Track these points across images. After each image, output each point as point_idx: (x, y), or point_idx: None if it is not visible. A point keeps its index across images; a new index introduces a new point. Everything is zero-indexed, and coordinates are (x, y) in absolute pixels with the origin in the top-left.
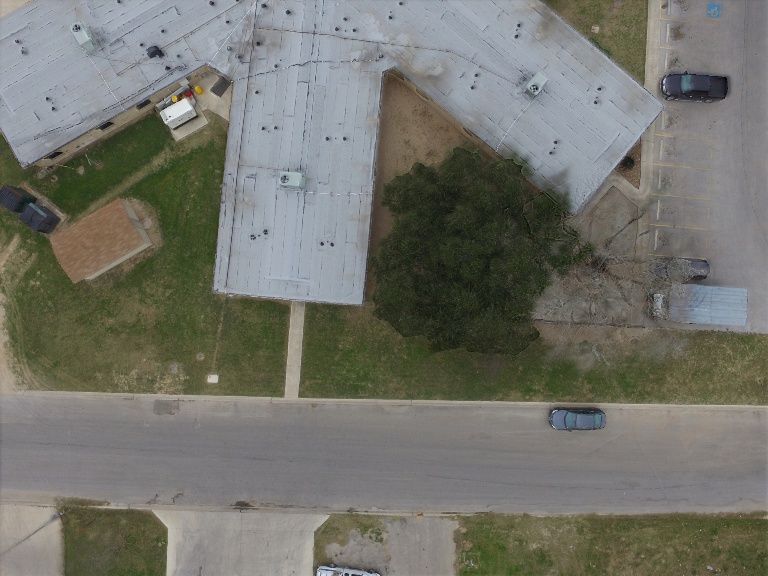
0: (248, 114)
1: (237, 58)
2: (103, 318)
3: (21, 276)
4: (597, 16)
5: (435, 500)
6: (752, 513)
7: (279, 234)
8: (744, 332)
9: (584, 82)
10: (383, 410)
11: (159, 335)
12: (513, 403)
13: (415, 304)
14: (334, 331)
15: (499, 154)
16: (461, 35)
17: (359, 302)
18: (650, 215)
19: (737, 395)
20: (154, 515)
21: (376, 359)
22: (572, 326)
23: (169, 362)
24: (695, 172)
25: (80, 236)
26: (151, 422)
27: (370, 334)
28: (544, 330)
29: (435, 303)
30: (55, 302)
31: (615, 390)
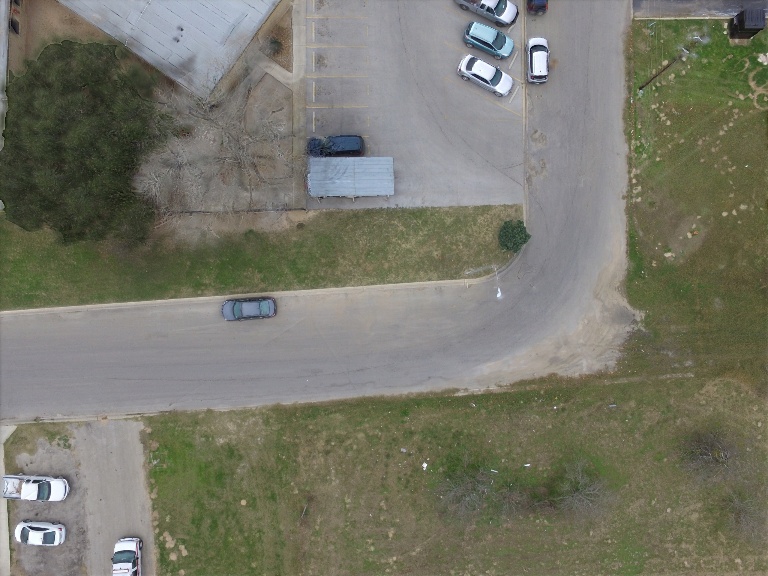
0: None
1: None
2: None
3: None
4: None
5: (118, 402)
6: (442, 391)
7: None
8: (415, 207)
9: None
10: (60, 318)
11: None
12: (187, 299)
13: (16, 193)
14: (3, 244)
15: (129, 48)
16: None
17: (2, 207)
18: (306, 98)
19: (414, 271)
20: None
21: (47, 267)
22: (233, 216)
23: None
24: (351, 51)
25: None
26: None
27: (38, 243)
28: None
29: (36, 190)
30: None
31: (287, 277)
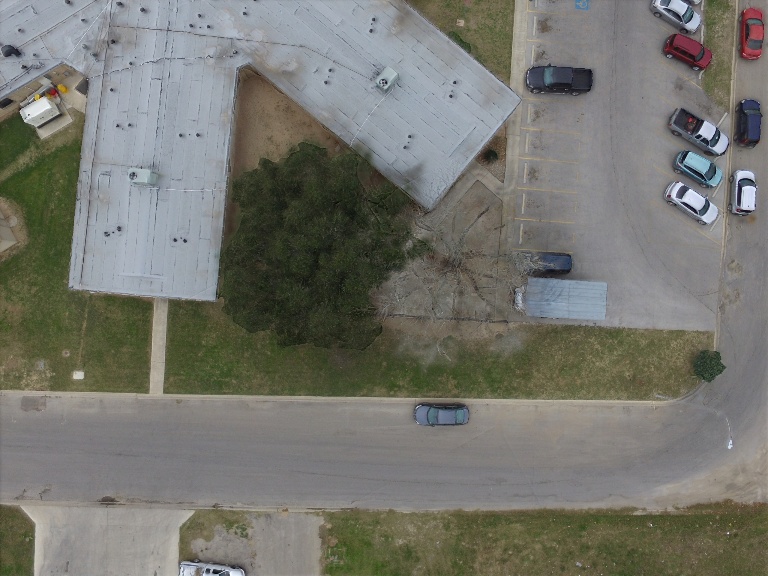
0: (103, 111)
1: (92, 56)
2: None
3: None
4: (462, 9)
5: (300, 496)
6: (622, 509)
7: (132, 231)
8: (612, 326)
9: (440, 76)
10: (248, 406)
11: (25, 332)
12: (378, 399)
13: (252, 299)
14: (197, 327)
15: (353, 149)
16: (315, 30)
17: (212, 298)
18: (515, 209)
19: (606, 390)
20: (22, 510)
21: (239, 355)
22: (435, 321)
23: (36, 359)
24: (562, 165)
25: None
26: (18, 418)
27: (233, 330)
28: (407, 325)
29: (272, 298)
30: None
31: (481, 385)
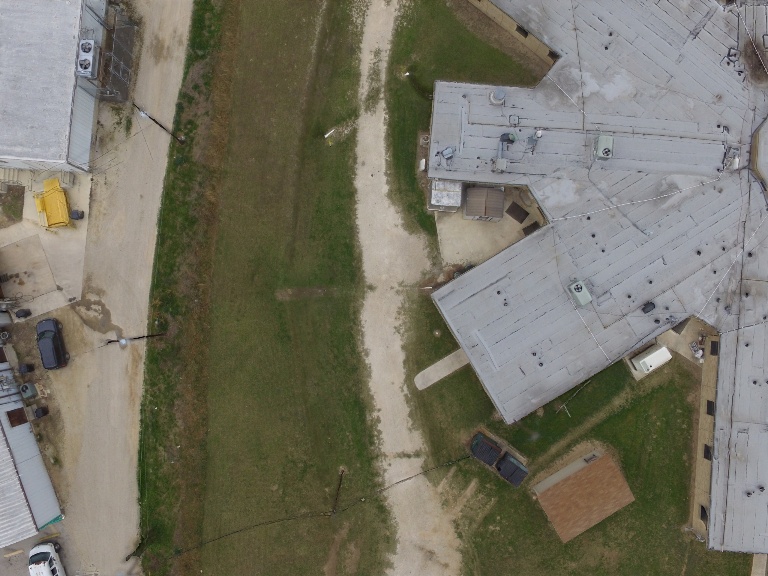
0: (738, 367)
1: (727, 310)
2: (566, 563)
3: (480, 521)
4: None
5: None
6: None
7: None
8: None
9: None
10: None
11: None
12: None
13: None
14: None
15: None
16: None
17: None
18: None
19: None
20: None
21: None
22: None
23: None
24: None
25: (572, 496)
26: None
27: None
28: None
29: None
30: (516, 548)
31: None
